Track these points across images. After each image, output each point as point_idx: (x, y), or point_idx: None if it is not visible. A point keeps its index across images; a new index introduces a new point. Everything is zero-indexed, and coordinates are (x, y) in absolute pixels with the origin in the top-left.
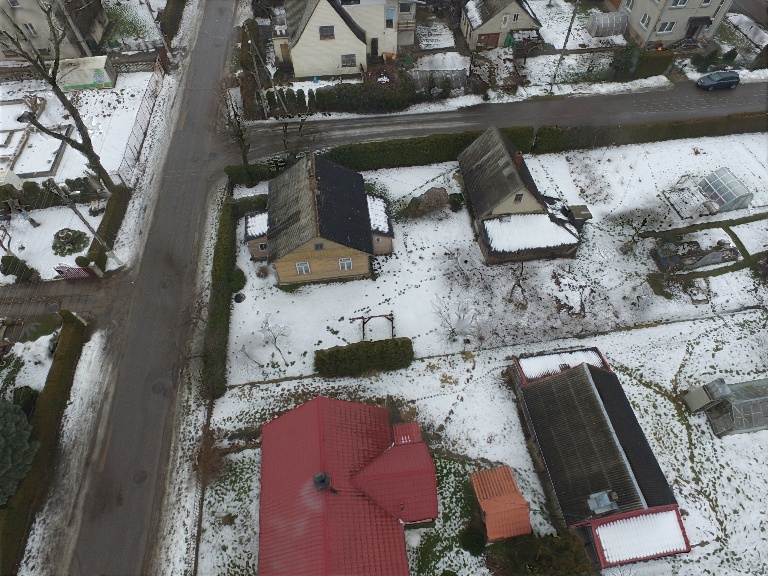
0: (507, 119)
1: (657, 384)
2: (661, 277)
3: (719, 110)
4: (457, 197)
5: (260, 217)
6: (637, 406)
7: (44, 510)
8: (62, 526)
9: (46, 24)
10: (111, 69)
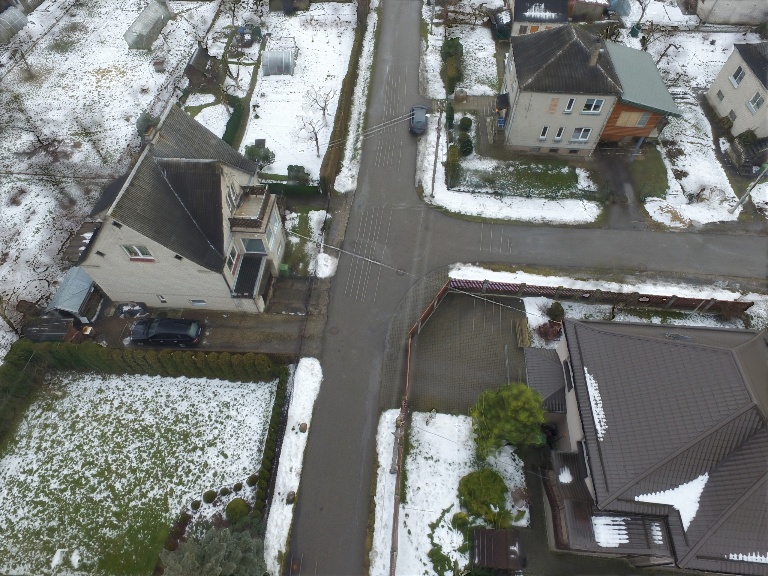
0: (401, 7)
1: (186, 12)
2: (237, 29)
3: (378, 108)
4: None
5: None
6: (182, 5)
7: None
8: None
9: None
10: None
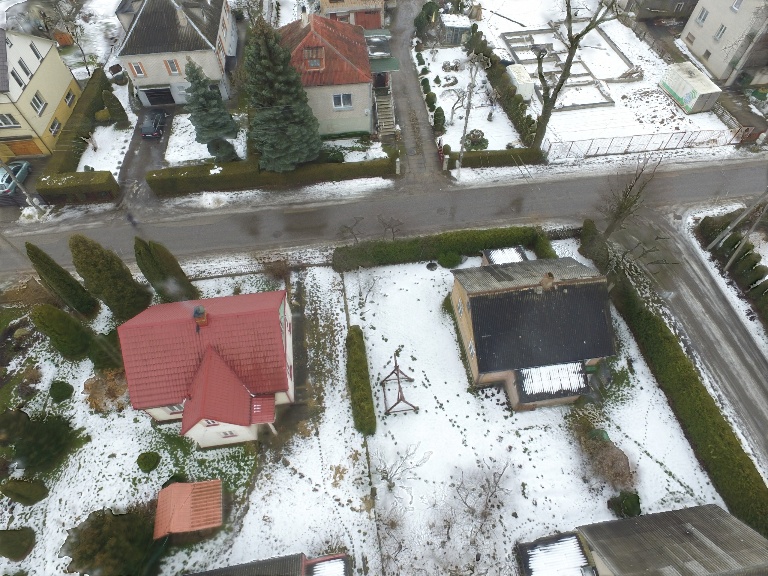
0: None
1: None
2: None
3: None
4: (627, 502)
5: (516, 256)
6: None
7: (264, 192)
8: (252, 203)
9: (734, 36)
10: (708, 102)
